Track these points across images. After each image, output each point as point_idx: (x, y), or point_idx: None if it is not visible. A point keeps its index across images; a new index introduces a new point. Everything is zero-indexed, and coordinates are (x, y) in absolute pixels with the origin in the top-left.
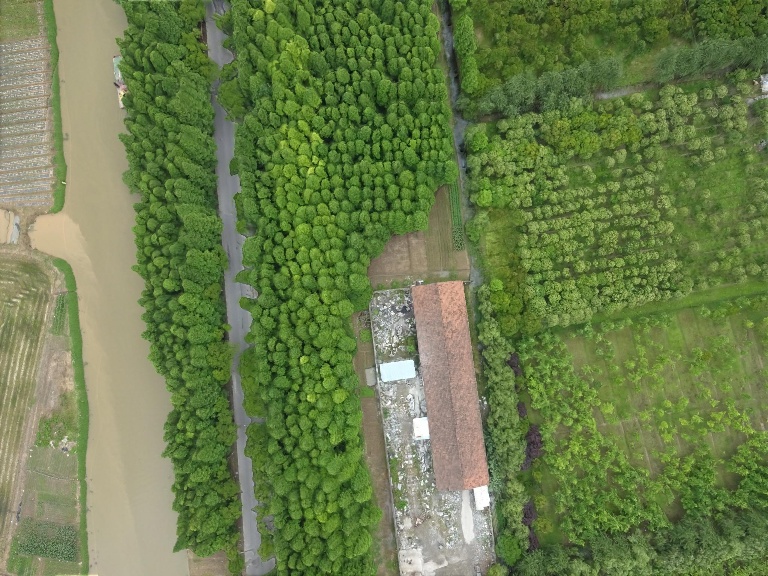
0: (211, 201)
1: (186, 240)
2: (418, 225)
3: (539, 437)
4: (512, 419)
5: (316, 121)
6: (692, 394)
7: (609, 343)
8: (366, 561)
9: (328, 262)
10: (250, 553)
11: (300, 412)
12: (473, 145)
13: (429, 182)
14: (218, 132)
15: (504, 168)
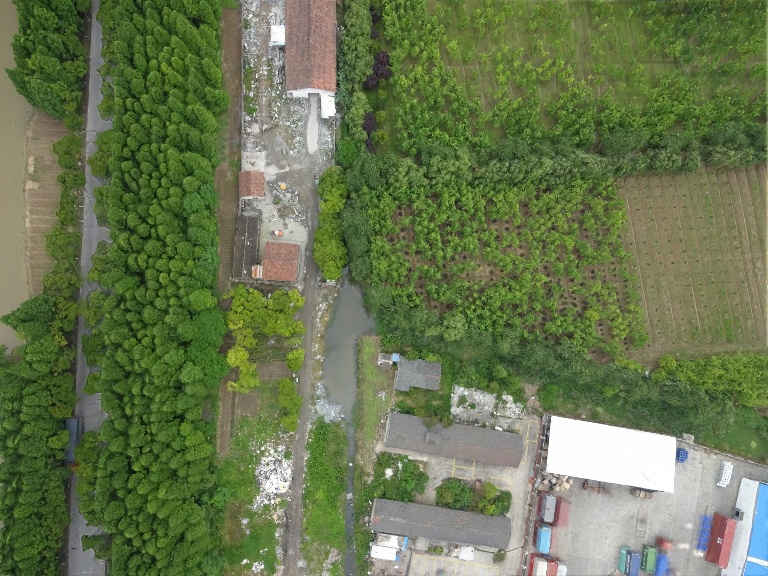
0: None
1: None
2: None
3: (387, 58)
4: (363, 27)
5: None
6: (528, 52)
7: None
8: None
9: None
10: (92, 133)
11: None
12: None
13: None
14: None
15: None
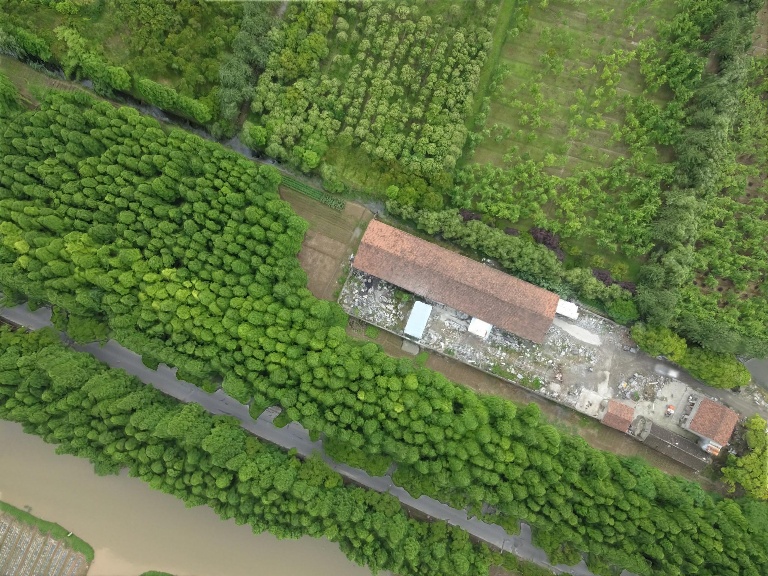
0: (169, 403)
1: (190, 442)
2: (300, 228)
3: (543, 231)
4: (515, 244)
5: (153, 263)
6: (577, 84)
7: (496, 126)
8: (568, 441)
9: (286, 325)
10: (506, 544)
11: (405, 425)
12: (258, 142)
13: (268, 196)
14: (110, 361)
15: (294, 127)
